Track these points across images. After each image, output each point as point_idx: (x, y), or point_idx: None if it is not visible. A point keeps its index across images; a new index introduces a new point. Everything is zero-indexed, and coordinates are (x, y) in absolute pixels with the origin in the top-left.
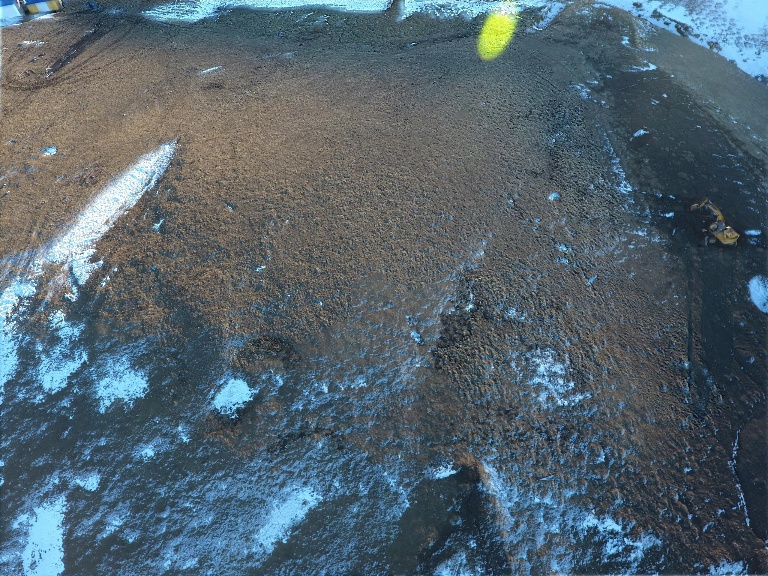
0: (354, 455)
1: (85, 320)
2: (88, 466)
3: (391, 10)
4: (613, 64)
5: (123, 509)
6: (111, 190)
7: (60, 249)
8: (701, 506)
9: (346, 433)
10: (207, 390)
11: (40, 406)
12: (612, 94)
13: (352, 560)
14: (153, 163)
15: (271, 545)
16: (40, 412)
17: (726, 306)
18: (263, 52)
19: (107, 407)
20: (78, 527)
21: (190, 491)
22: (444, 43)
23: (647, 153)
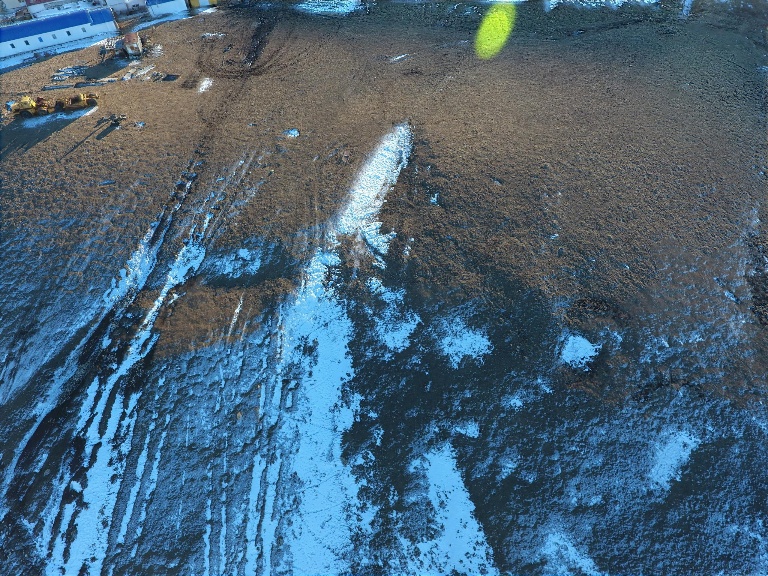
0: (717, 402)
1: (404, 285)
2: (463, 415)
3: (534, 1)
4: None
5: (513, 453)
6: (369, 168)
7: (346, 222)
8: None
9: (702, 383)
10: (552, 346)
11: (392, 363)
12: None
13: (751, 495)
14: (396, 143)
15: (667, 483)
16: (394, 368)
17: None
18: (440, 41)
19: (459, 363)
20: (475, 470)
21: (572, 436)
22: (613, 30)
23: None
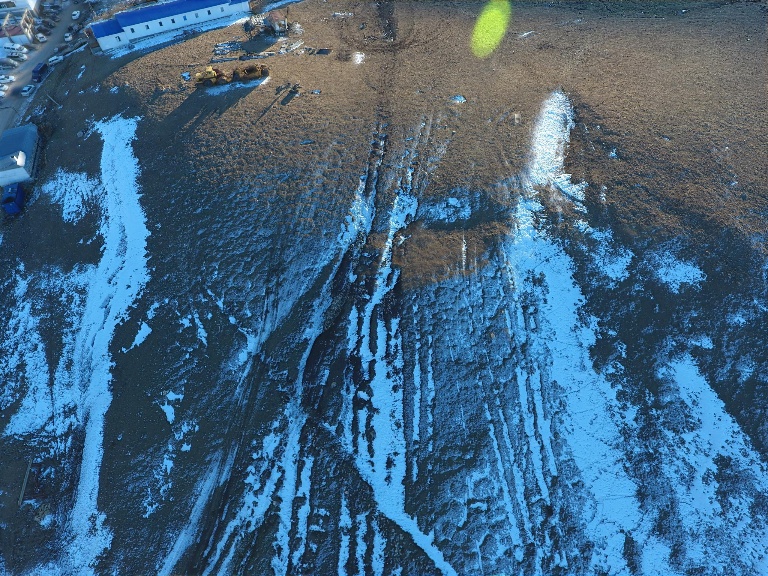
0: None
1: (610, 226)
2: (696, 331)
3: None
4: None
5: (747, 360)
6: (542, 128)
7: (538, 174)
8: None
9: None
10: (759, 273)
11: (618, 290)
12: None
13: None
14: (557, 107)
15: None
16: (621, 294)
17: None
18: (557, 19)
19: (678, 289)
20: (717, 374)
21: None
22: (716, 9)
23: None
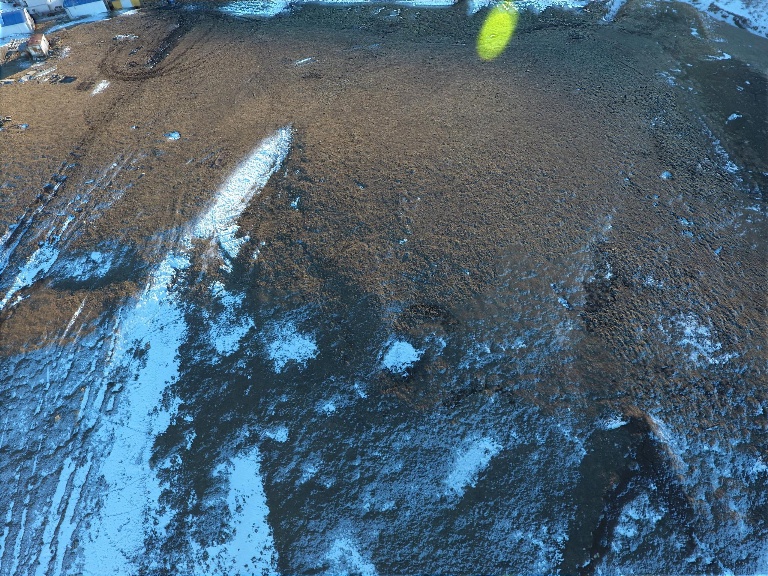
0: (526, 409)
1: (245, 289)
2: (275, 420)
3: (460, 4)
4: (689, 53)
5: (316, 458)
6: (240, 171)
7: (205, 225)
8: None
9: (515, 389)
10: (375, 351)
11: (217, 367)
12: (697, 81)
13: (541, 502)
14: (274, 147)
15: (461, 489)
16: (218, 372)
17: None
18: (350, 44)
19: (282, 367)
20: (276, 474)
21: (377, 441)
22: (524, 34)
23: (745, 135)
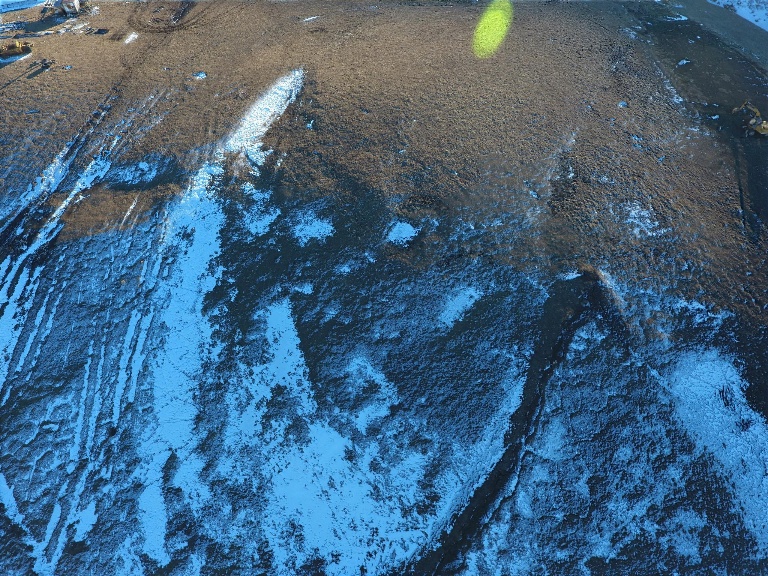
0: (502, 267)
1: (271, 188)
2: (302, 279)
3: None
4: (651, 15)
5: (336, 304)
6: (261, 102)
7: (234, 143)
8: (761, 294)
9: (494, 254)
10: (381, 229)
11: (252, 244)
12: (655, 35)
13: (513, 329)
14: (289, 84)
15: (451, 323)
16: (253, 247)
17: (766, 176)
18: (350, 6)
19: (305, 243)
20: (304, 316)
21: (384, 291)
22: None
23: (691, 75)
